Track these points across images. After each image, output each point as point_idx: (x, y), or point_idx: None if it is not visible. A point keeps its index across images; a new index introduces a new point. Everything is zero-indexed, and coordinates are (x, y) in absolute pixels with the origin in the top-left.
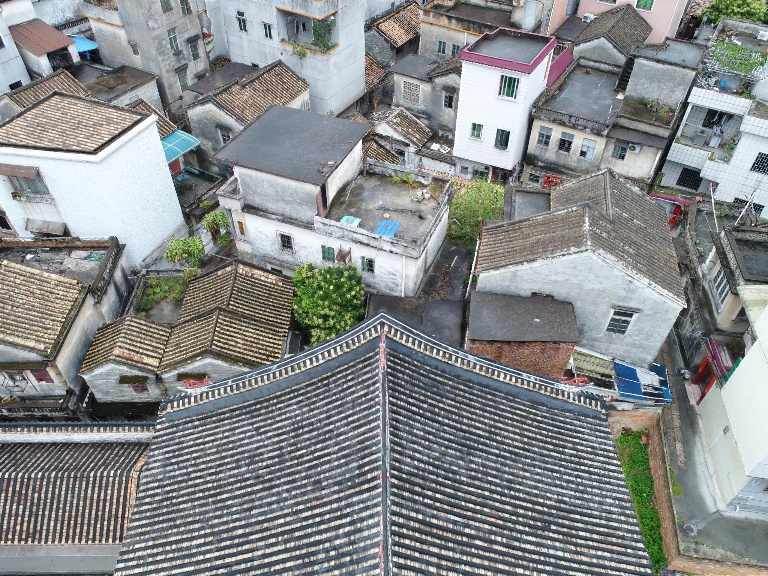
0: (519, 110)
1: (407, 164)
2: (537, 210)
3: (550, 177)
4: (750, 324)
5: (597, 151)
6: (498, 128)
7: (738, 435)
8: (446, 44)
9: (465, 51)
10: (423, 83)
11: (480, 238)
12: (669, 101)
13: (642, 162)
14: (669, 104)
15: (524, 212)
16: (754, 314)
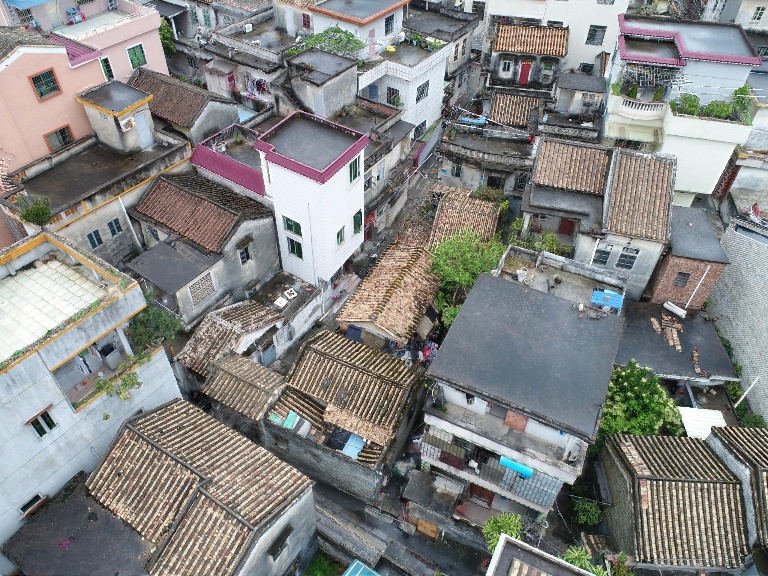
0: (362, 183)
1: (277, 347)
2: (559, 197)
3: (371, 219)
4: (640, 141)
5: (386, 167)
6: (354, 215)
7: (687, 187)
8: (99, 231)
9: (324, 171)
10: (213, 266)
11: (604, 238)
12: (350, 100)
13: (395, 150)
14: (351, 102)
15: (564, 205)
16: (633, 137)
